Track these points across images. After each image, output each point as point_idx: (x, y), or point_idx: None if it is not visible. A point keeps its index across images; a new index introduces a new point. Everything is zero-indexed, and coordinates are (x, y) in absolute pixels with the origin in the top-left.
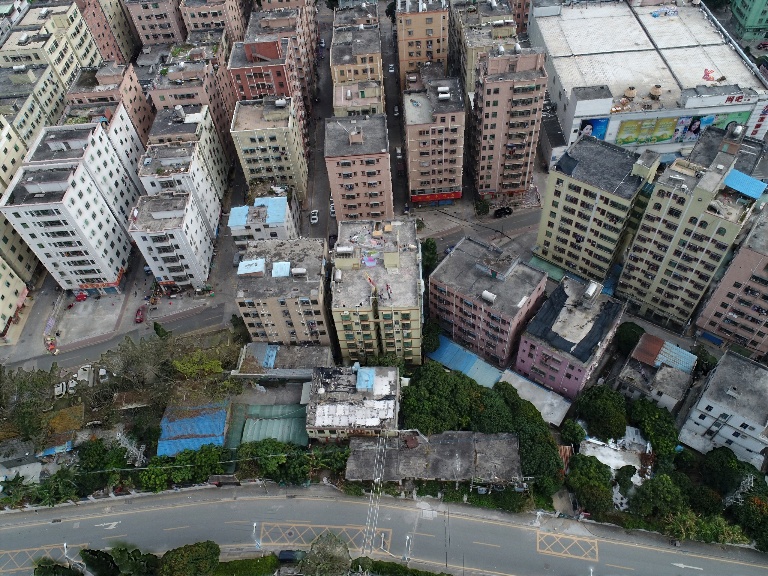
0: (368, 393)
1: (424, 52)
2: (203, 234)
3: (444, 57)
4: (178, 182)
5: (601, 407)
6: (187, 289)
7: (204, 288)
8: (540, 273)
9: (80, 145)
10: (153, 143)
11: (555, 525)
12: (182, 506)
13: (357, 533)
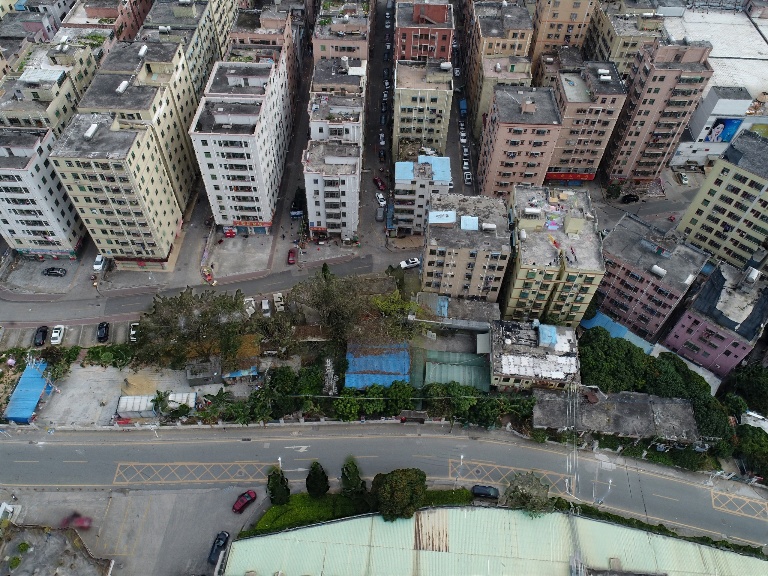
0: (549, 348)
1: (562, 35)
2: (358, 185)
3: (580, 43)
4: (346, 131)
5: (765, 383)
6: (334, 237)
7: (351, 238)
8: (702, 255)
9: (259, 83)
10: (316, 91)
11: (727, 486)
12: (368, 437)
13: (542, 476)
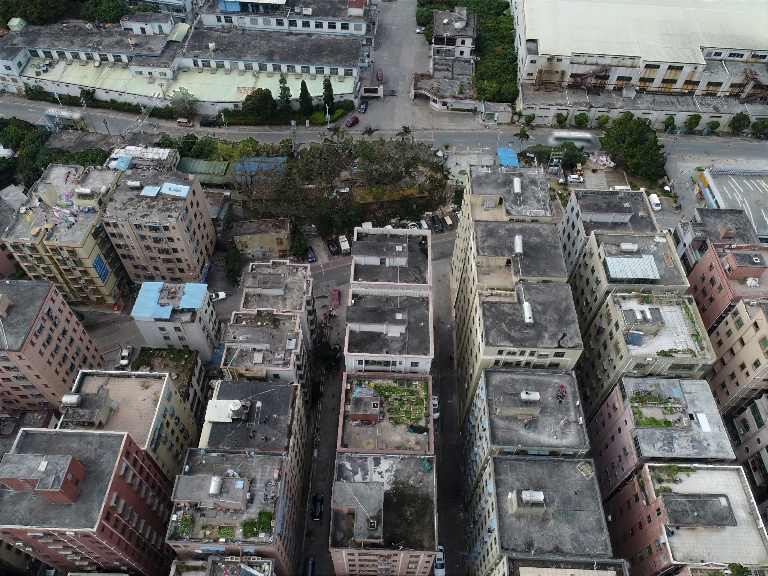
0: None
1: None
2: None
3: None
4: None
5: None
6: None
7: None
8: None
9: None
10: None
11: None
12: None
13: (169, 132)
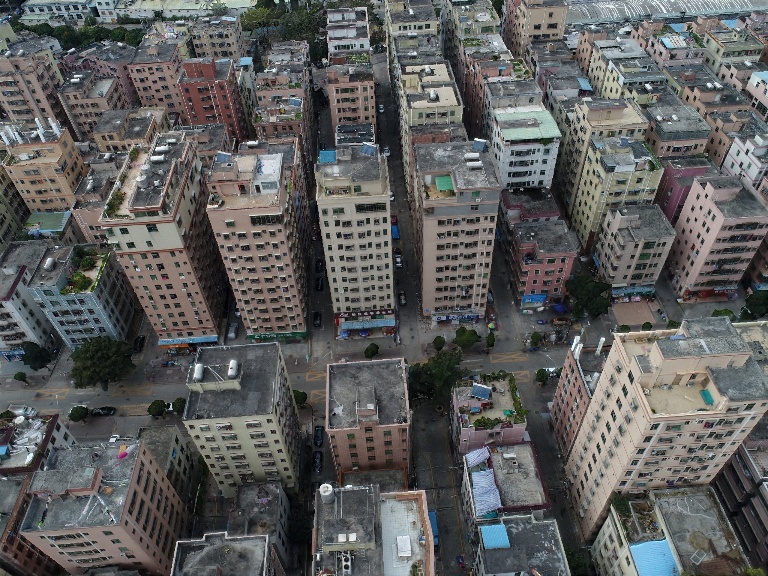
0: None
1: None
2: None
3: None
4: None
5: None
6: None
7: None
8: None
9: None
10: None
11: None
12: None
13: None
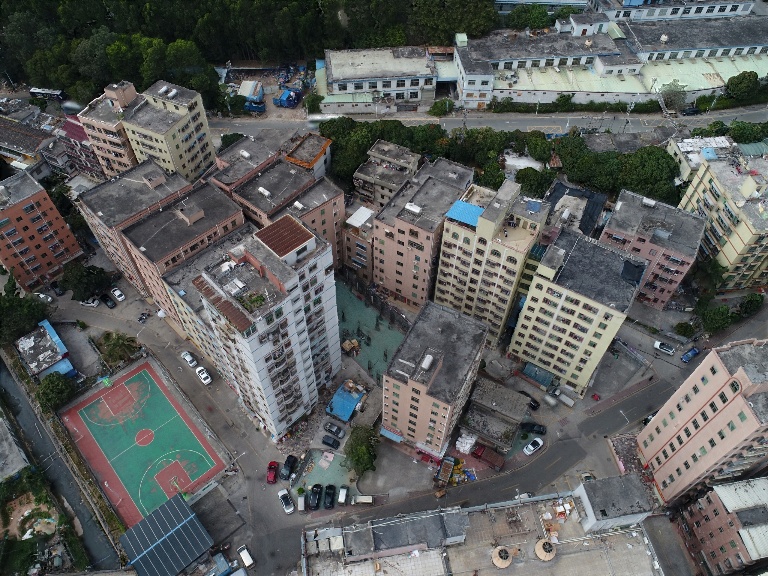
0: None
1: None
2: None
3: None
4: None
5: (538, 172)
6: None
7: None
8: None
9: None
10: None
11: None
12: None
13: (662, 124)
